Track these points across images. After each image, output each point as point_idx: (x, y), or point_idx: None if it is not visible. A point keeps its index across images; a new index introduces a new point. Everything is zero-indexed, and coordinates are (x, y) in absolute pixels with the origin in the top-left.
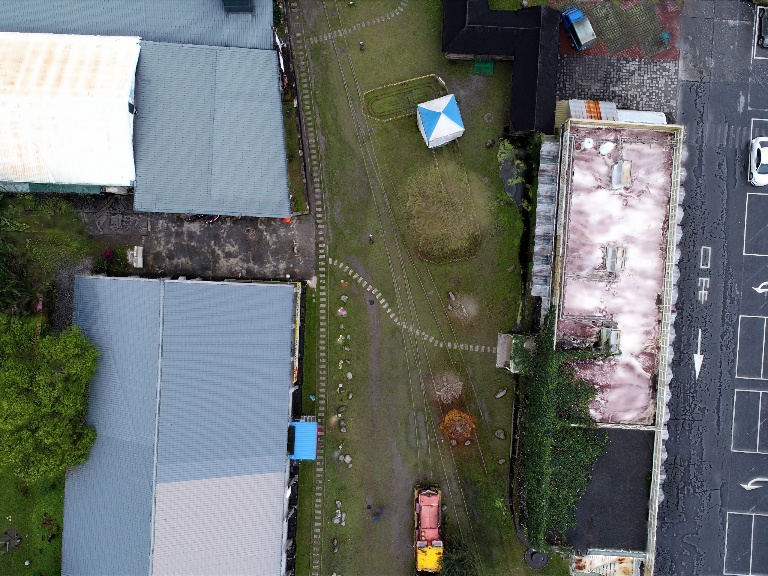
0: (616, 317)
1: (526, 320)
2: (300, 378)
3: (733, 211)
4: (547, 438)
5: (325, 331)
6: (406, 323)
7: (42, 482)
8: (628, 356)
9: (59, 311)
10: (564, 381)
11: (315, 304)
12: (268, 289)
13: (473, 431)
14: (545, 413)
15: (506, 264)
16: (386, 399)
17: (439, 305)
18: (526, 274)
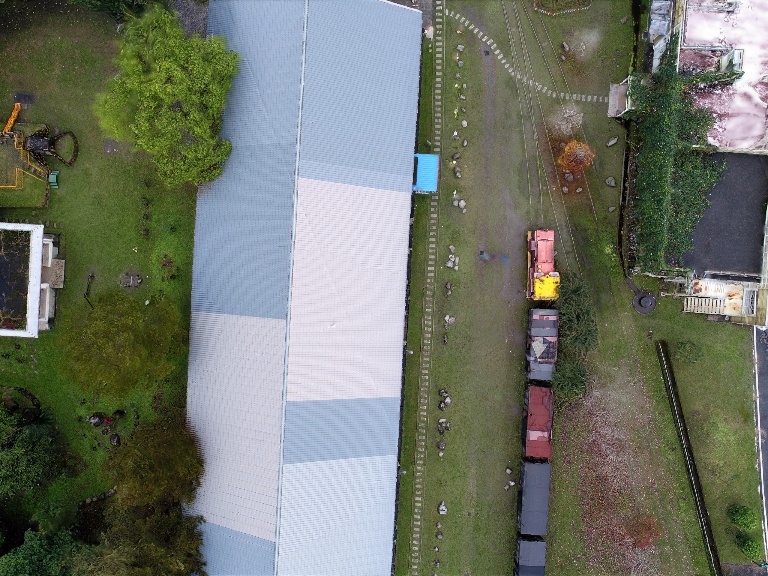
0: (735, 47)
1: (638, 71)
2: (417, 123)
3: None
4: (669, 157)
5: (441, 80)
6: (520, 73)
7: (162, 225)
8: (746, 85)
9: None
10: (683, 109)
11: (431, 54)
12: (400, 10)
13: (584, 179)
14: (667, 134)
15: (619, 16)
16: (500, 147)
17: (552, 56)
18: (638, 26)
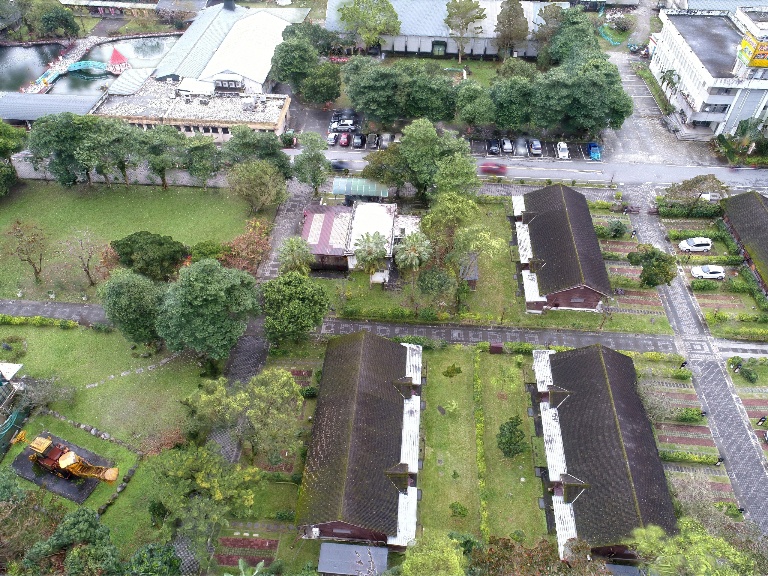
0: None
1: None
2: None
3: None
4: None
5: None
6: None
7: None
8: None
9: None
10: None
11: None
12: None
13: None
14: None
15: None
16: None
17: None
18: None
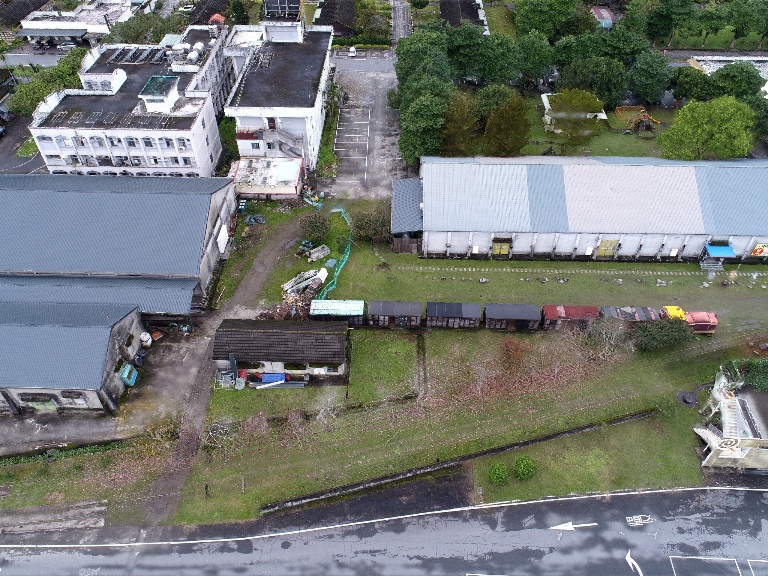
0: None
1: None
2: (748, 261)
3: None
4: None
5: None
6: None
7: None
8: None
9: None
10: None
11: None
12: None
13: (767, 357)
14: None
15: None
16: (759, 306)
17: None
18: None
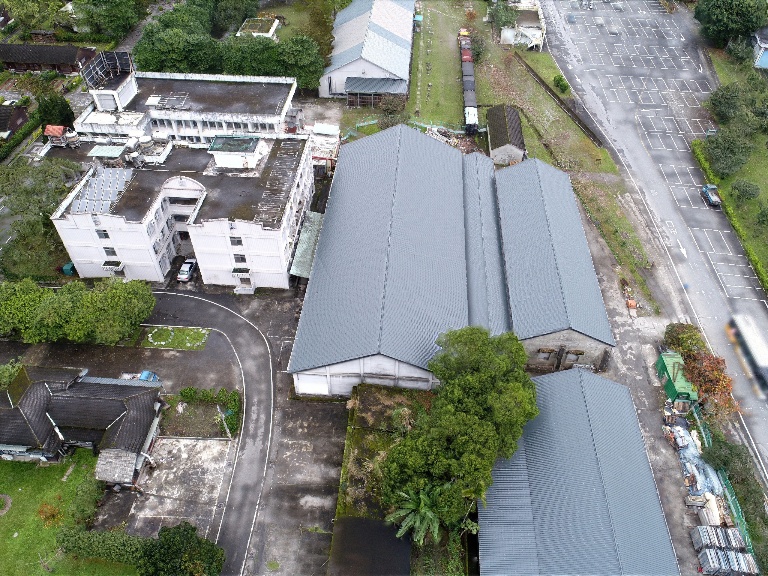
0: None
1: None
2: None
3: (556, 3)
4: None
5: None
6: None
7: None
8: None
9: (331, 12)
10: None
11: None
12: None
13: None
14: None
15: None
16: None
17: None
18: None
